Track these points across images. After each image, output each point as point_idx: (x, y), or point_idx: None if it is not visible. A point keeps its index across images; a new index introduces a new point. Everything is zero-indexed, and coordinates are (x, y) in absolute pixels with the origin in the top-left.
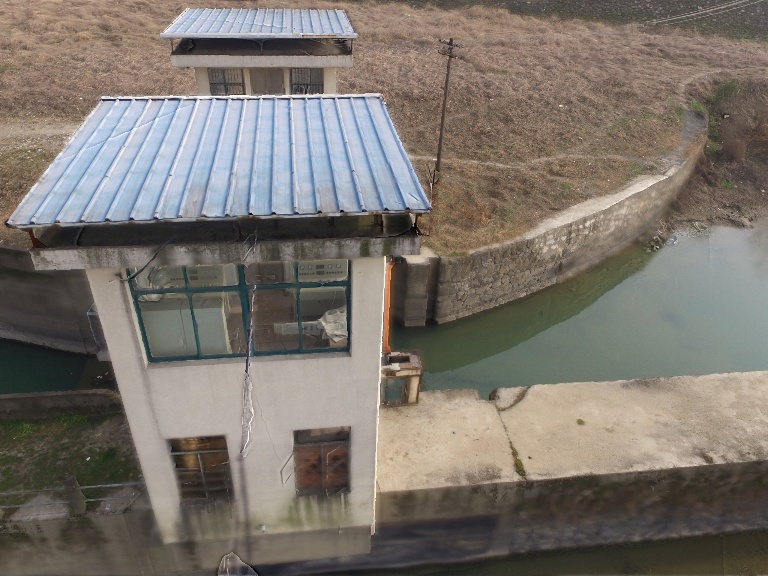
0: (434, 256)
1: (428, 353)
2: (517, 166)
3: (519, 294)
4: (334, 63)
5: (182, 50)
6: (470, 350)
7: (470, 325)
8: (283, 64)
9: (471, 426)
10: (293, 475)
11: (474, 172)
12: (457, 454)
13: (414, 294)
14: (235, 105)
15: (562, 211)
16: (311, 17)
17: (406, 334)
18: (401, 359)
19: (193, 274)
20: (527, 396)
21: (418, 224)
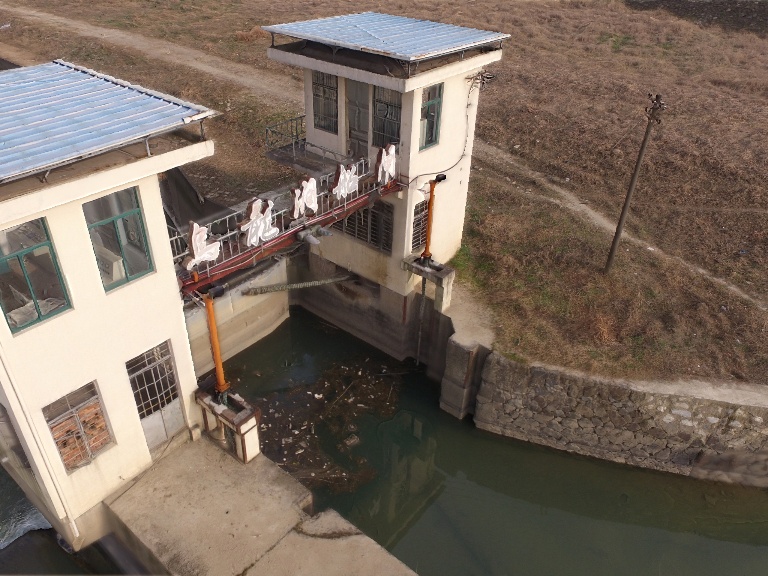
0: (487, 346)
1: (464, 453)
2: (759, 300)
3: (611, 455)
4: (388, 84)
5: (296, 46)
6: (522, 483)
7: (523, 452)
8: (346, 75)
9: (249, 519)
10: (1, 425)
11: (680, 282)
12: (199, 531)
13: (452, 376)
14: (102, 87)
15: (743, 383)
16: (441, 35)
17: (438, 416)
18: (239, 407)
19: (38, 223)
20: (341, 539)
21: (516, 305)
